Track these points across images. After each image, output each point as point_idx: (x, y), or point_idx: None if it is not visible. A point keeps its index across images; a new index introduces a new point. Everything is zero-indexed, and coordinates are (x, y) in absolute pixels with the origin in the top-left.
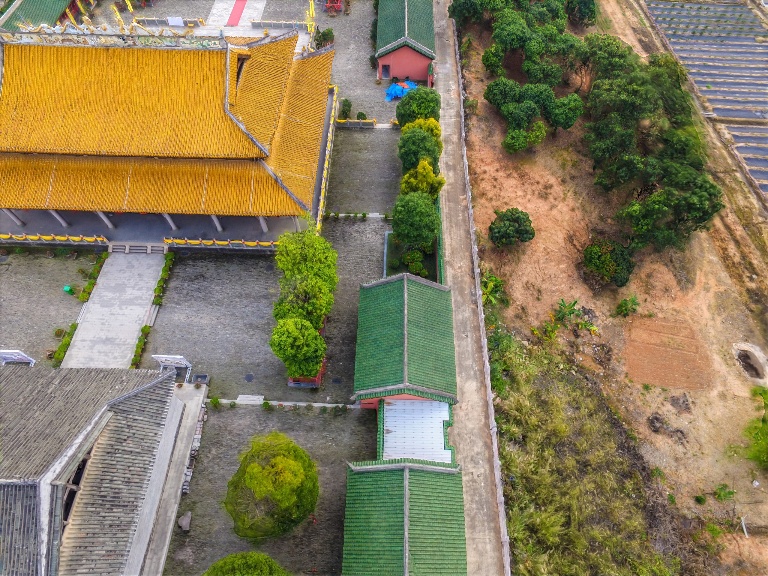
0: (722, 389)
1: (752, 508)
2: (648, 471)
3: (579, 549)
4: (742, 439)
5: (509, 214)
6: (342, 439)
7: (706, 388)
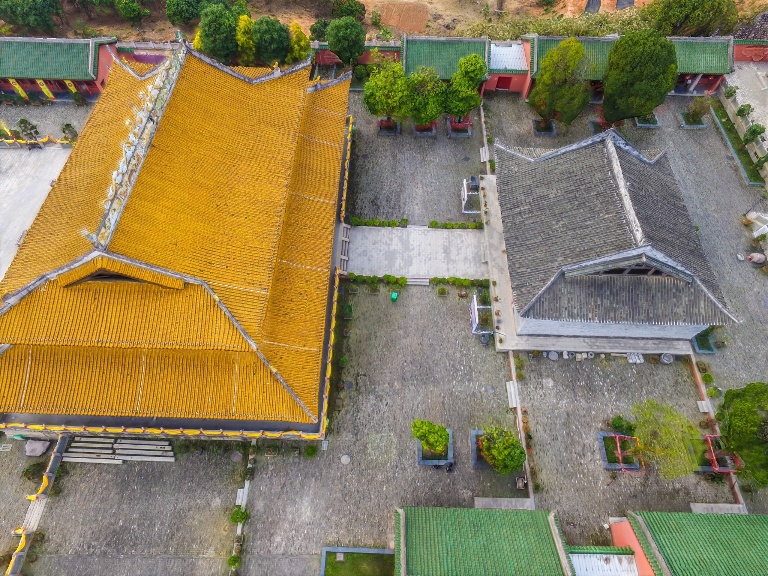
0: (426, 2)
1: (490, 7)
2: None
3: (543, 23)
4: (455, 2)
5: (320, 26)
6: (504, 107)
7: (426, 7)
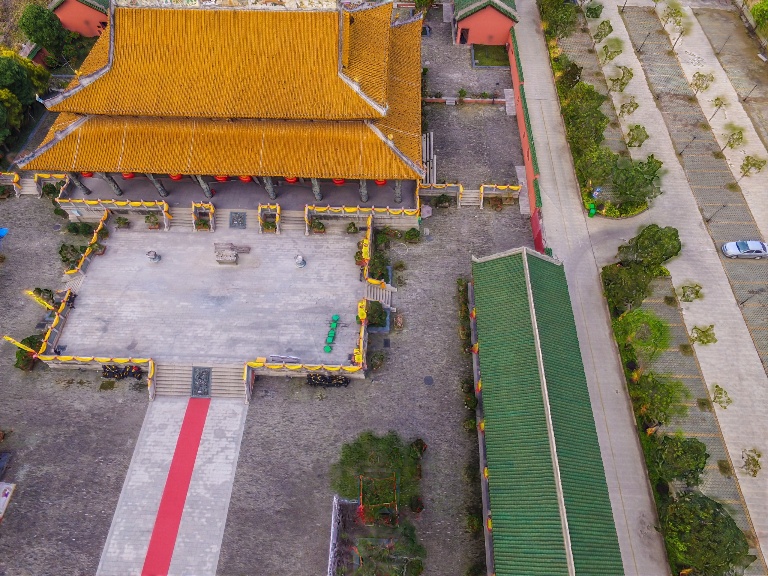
0: None
1: None
2: (7, 32)
3: None
4: None
5: None
6: None
7: None
